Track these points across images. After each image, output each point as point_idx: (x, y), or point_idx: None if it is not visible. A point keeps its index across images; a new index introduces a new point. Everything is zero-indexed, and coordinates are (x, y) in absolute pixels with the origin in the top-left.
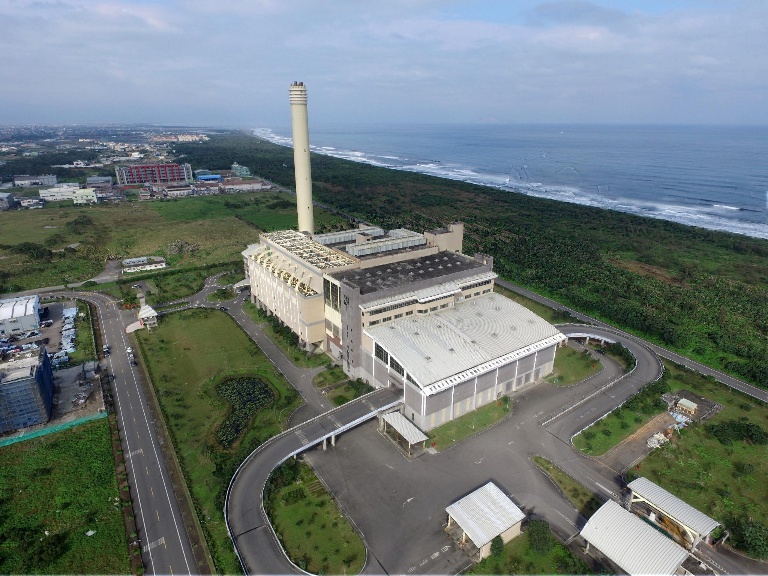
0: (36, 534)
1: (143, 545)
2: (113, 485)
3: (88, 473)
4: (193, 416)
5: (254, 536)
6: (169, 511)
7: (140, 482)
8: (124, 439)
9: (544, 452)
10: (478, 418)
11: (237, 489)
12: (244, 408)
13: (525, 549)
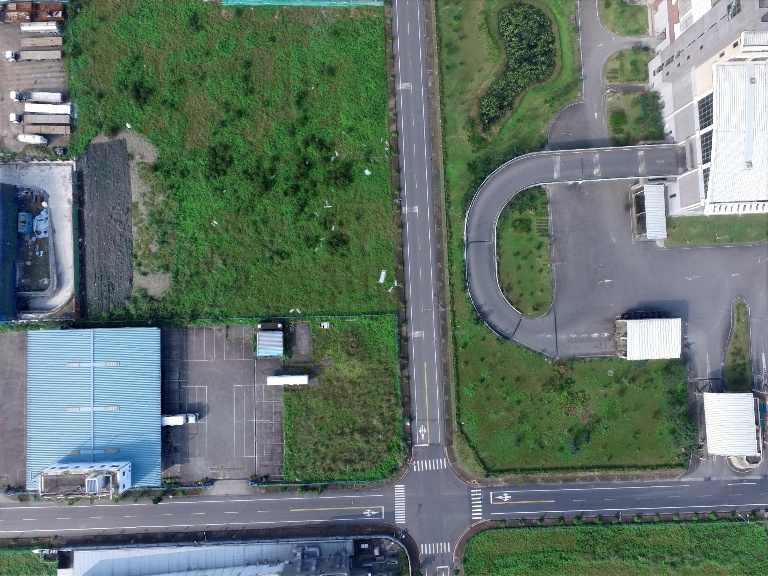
0: (330, 151)
1: (403, 206)
2: (385, 123)
3: (365, 96)
4: (465, 56)
5: (481, 249)
6: (425, 181)
7: (406, 132)
8: (397, 57)
9: (754, 302)
10: (733, 228)
11: (482, 197)
12: (518, 71)
13: (658, 368)
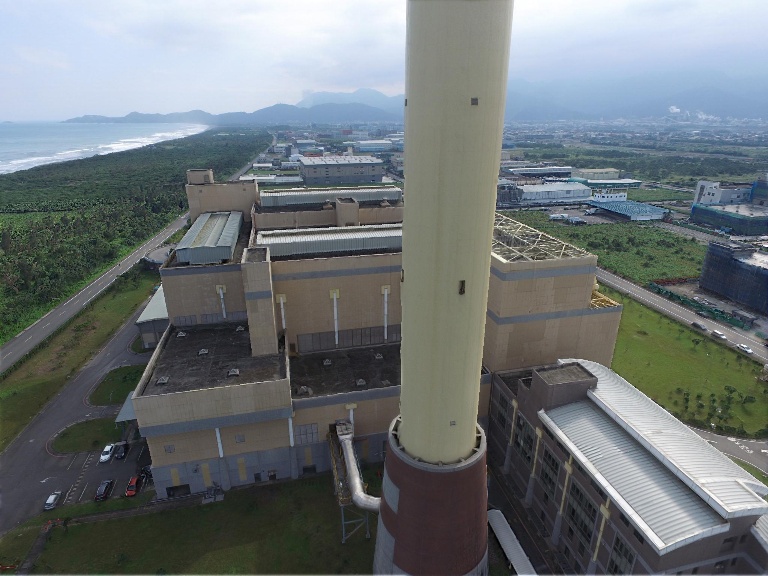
0: None
1: None
2: None
3: None
4: None
5: None
6: None
7: None
8: None
9: None
10: None
11: None
12: None
13: None
